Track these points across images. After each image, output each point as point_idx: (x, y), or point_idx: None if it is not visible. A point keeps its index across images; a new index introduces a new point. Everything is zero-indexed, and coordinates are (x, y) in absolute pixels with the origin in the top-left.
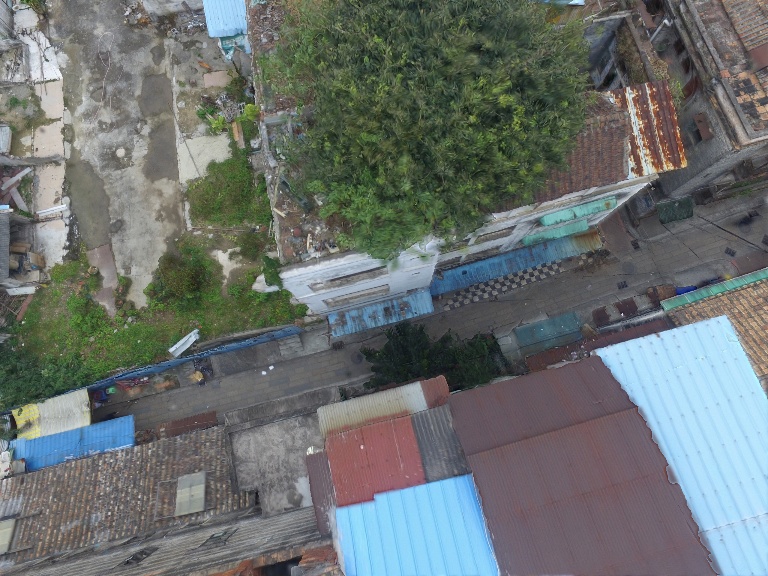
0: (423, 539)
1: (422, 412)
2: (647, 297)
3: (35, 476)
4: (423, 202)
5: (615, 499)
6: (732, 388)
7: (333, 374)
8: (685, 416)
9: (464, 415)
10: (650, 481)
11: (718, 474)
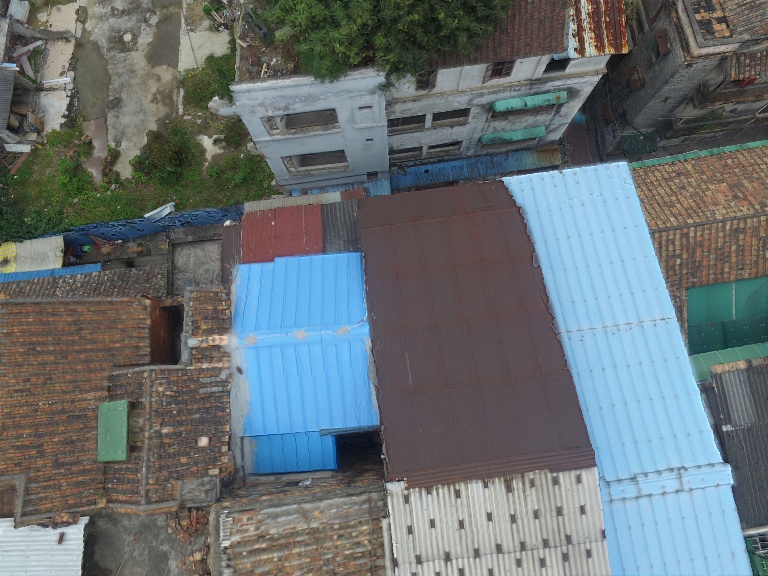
0: (308, 290)
1: (332, 203)
2: None
3: (0, 285)
4: (358, 14)
5: (481, 272)
6: (619, 221)
7: None
8: (571, 239)
9: (369, 208)
10: (516, 262)
11: (591, 288)
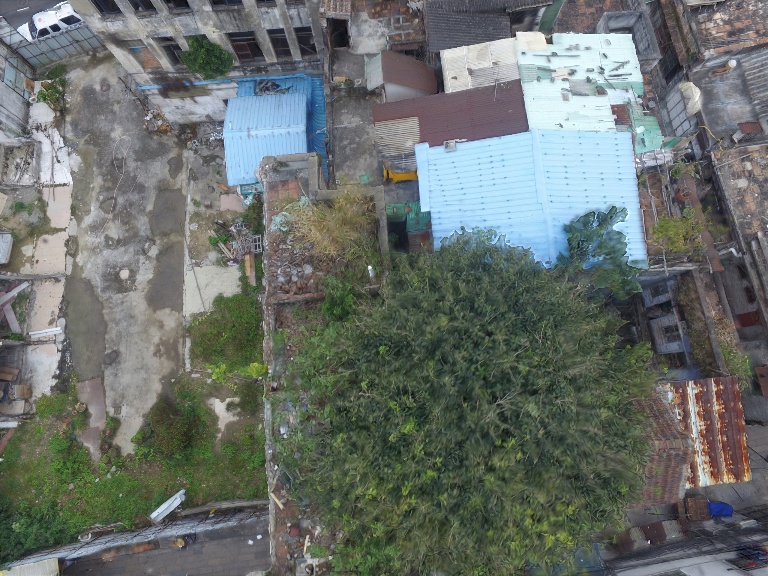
0: None
1: None
2: (678, 524)
3: None
4: None
5: None
6: None
7: None
8: None
9: None
10: None
11: None
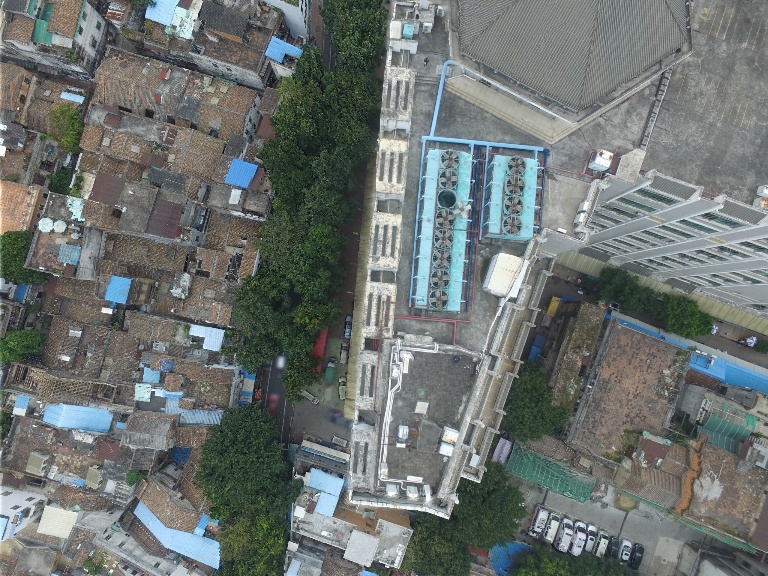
0: None
1: None
2: None
3: None
4: None
5: None
6: None
7: None
8: None
9: None
10: None
11: None
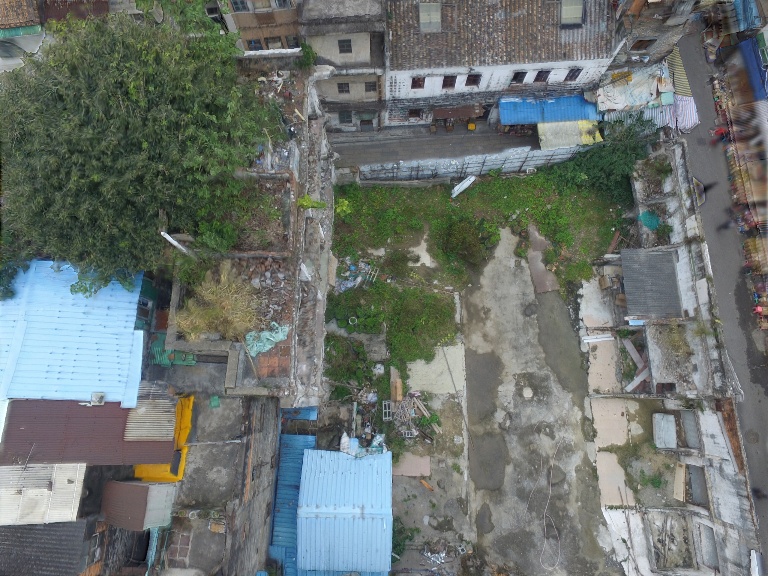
0: None
1: None
2: None
3: (555, 57)
4: None
5: None
6: None
7: (344, 152)
8: None
9: None
10: None
11: None
